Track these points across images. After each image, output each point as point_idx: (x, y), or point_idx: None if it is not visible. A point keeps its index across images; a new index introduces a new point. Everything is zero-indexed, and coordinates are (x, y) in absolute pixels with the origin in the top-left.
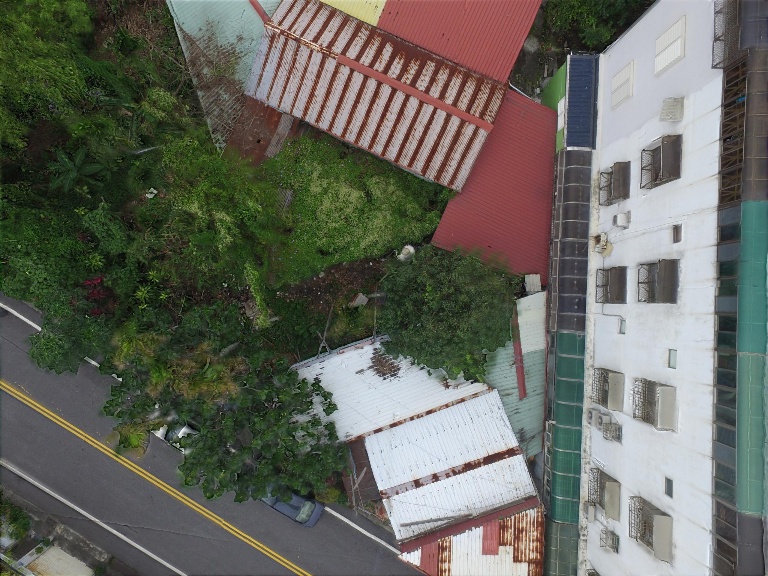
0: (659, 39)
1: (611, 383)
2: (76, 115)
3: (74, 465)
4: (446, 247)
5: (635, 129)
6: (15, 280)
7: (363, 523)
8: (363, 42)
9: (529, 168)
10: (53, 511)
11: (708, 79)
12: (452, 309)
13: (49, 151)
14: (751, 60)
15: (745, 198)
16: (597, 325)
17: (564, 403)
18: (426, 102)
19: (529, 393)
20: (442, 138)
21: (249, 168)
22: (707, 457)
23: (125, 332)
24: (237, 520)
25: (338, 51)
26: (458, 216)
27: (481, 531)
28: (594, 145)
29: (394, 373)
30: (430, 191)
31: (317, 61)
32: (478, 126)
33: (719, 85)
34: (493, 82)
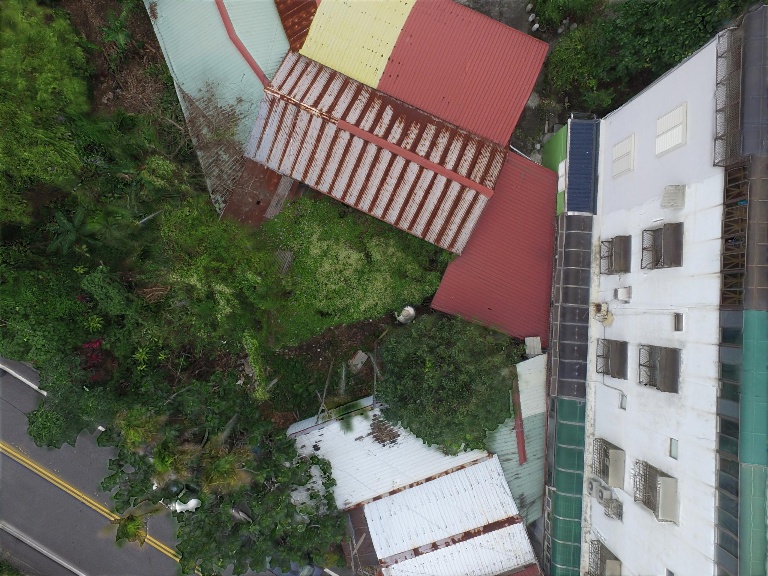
0: (660, 120)
1: (612, 459)
2: (75, 175)
3: (72, 527)
4: (446, 310)
5: (636, 204)
6: (13, 343)
7: None
8: (363, 105)
9: (529, 230)
10: (50, 573)
11: (710, 173)
12: (452, 387)
13: (48, 207)
14: (753, 167)
15: (747, 306)
16: (598, 393)
17: (564, 470)
18: (426, 167)
19: (529, 458)
20: (442, 202)
21: (248, 229)
22: (709, 559)
23: (123, 395)
24: None
25: (338, 116)
26: (458, 278)
27: None
28: (595, 211)
29: (393, 440)
30: (430, 250)
31: (317, 126)
32: (478, 192)
33: (721, 183)
34: (493, 145)
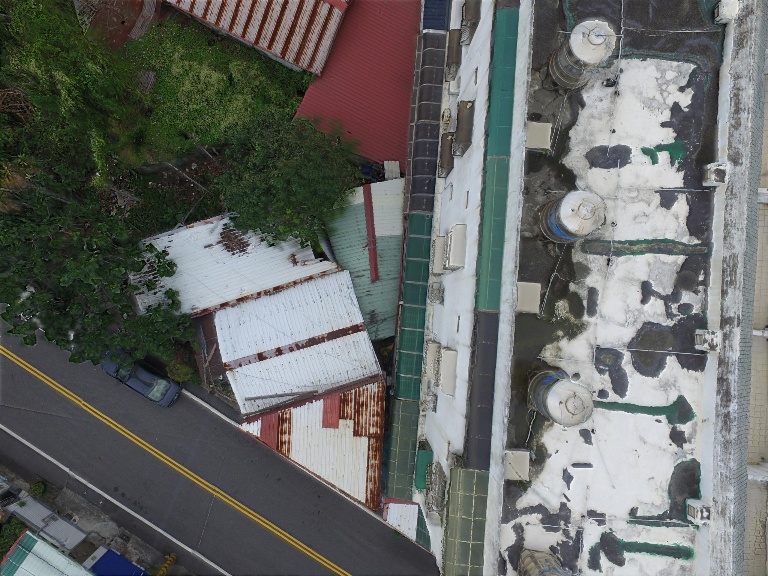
0: None
1: (437, 247)
2: None
3: None
4: None
5: None
6: None
7: (224, 409)
8: None
9: (392, 56)
10: None
11: None
12: None
13: None
14: None
15: (499, 5)
16: (442, 203)
17: (411, 282)
18: None
19: (382, 276)
20: (299, 18)
21: (113, 49)
22: (474, 276)
23: None
24: (97, 401)
25: None
26: (318, 101)
27: (321, 404)
28: (448, 27)
29: (243, 249)
30: (298, 81)
31: None
32: (332, 5)
33: None
34: None
